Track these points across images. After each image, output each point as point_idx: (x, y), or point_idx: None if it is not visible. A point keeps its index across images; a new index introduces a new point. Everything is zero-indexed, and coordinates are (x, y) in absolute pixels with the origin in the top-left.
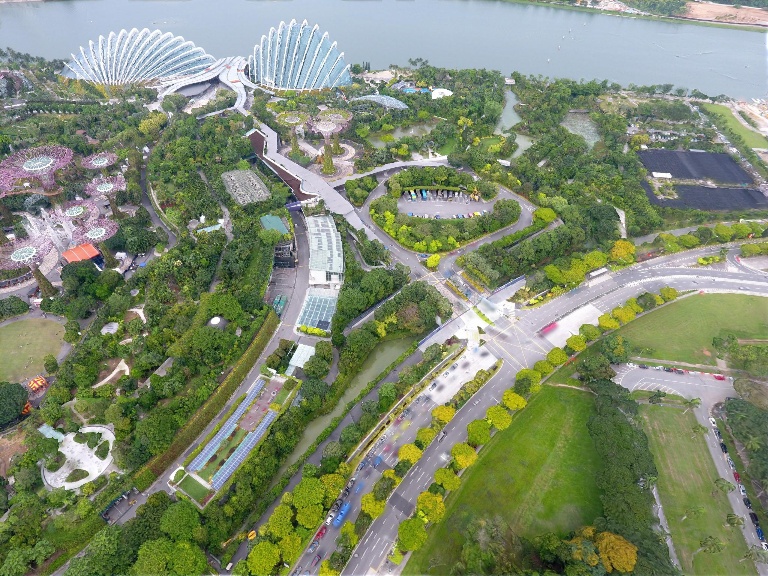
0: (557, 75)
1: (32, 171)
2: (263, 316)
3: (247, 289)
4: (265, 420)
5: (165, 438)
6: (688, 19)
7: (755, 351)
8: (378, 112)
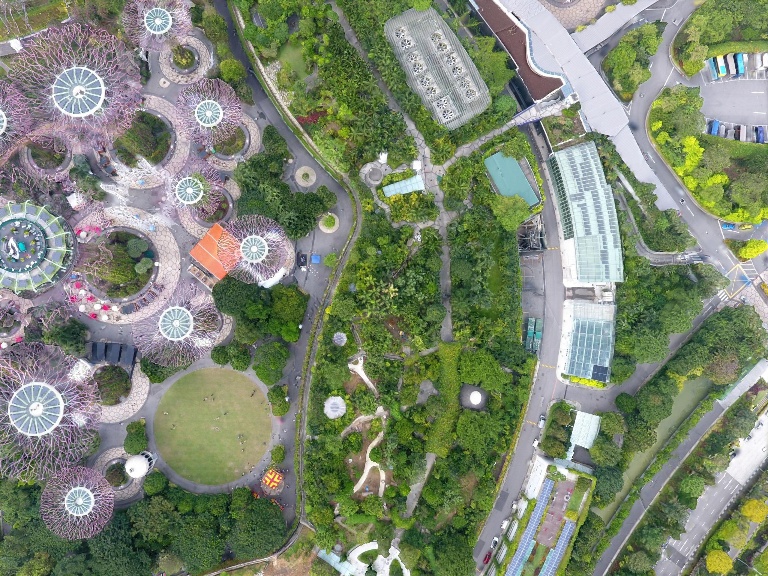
0: None
1: (81, 119)
2: (528, 374)
3: (499, 330)
4: (565, 534)
5: (472, 575)
6: None
7: None
8: None
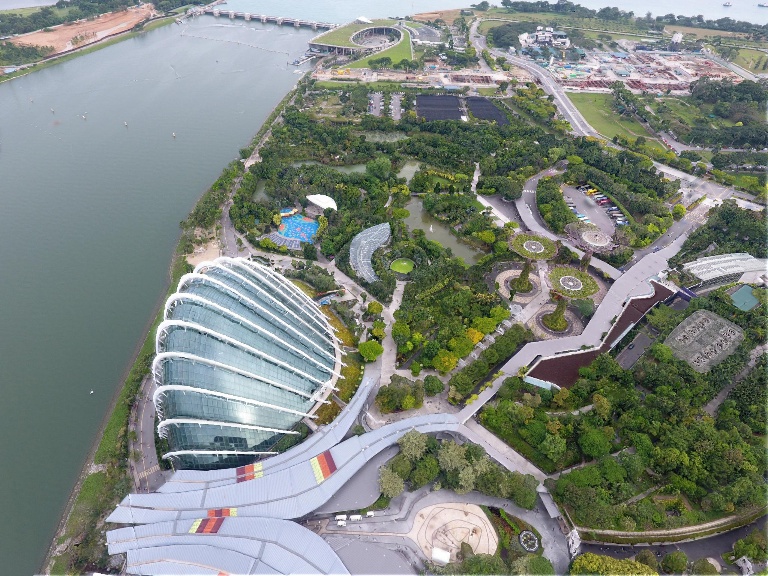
0: (219, 137)
1: None
2: None
3: None
4: None
5: None
6: (64, 54)
7: (658, 122)
8: (402, 250)
